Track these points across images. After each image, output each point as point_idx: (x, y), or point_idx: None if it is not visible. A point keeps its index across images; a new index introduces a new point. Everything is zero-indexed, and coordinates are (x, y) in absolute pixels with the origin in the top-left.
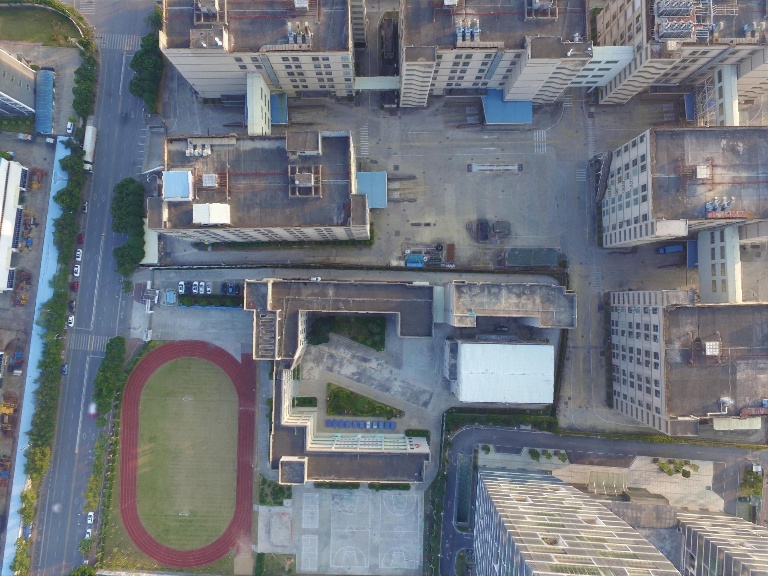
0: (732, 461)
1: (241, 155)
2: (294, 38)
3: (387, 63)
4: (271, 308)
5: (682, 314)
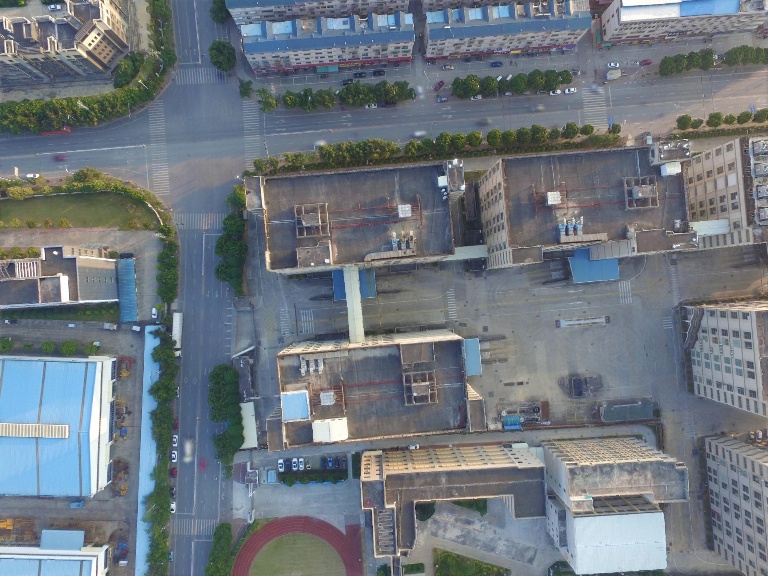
0: None
1: (353, 365)
2: (398, 244)
3: (469, 224)
4: (386, 501)
5: None
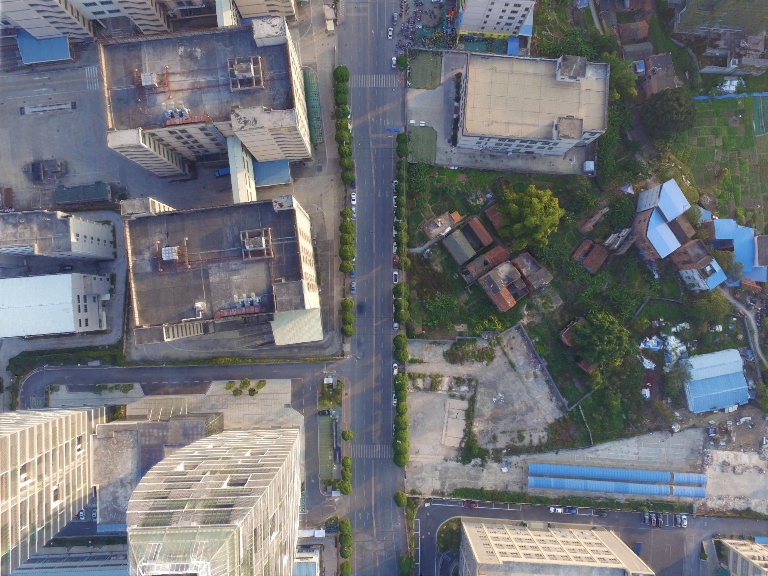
0: (309, 376)
1: None
2: None
3: None
4: None
5: (151, 224)
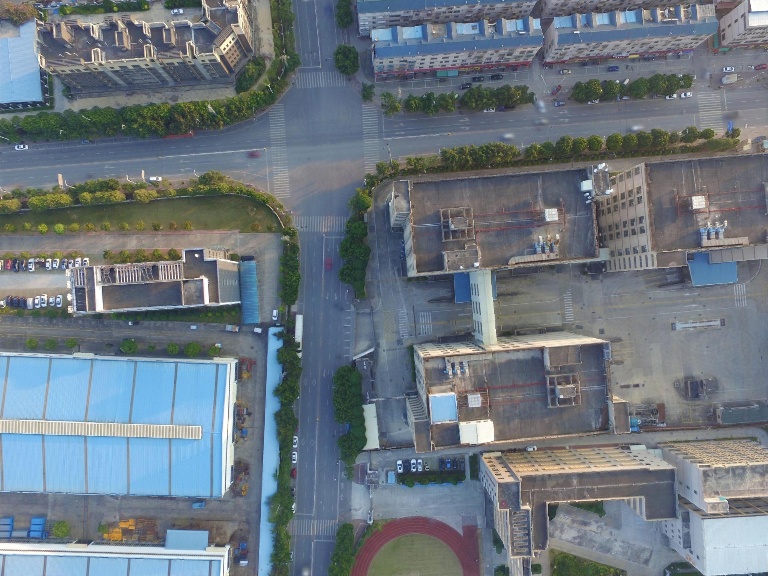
0: None
1: (497, 368)
2: (541, 247)
3: None
4: None
5: None
